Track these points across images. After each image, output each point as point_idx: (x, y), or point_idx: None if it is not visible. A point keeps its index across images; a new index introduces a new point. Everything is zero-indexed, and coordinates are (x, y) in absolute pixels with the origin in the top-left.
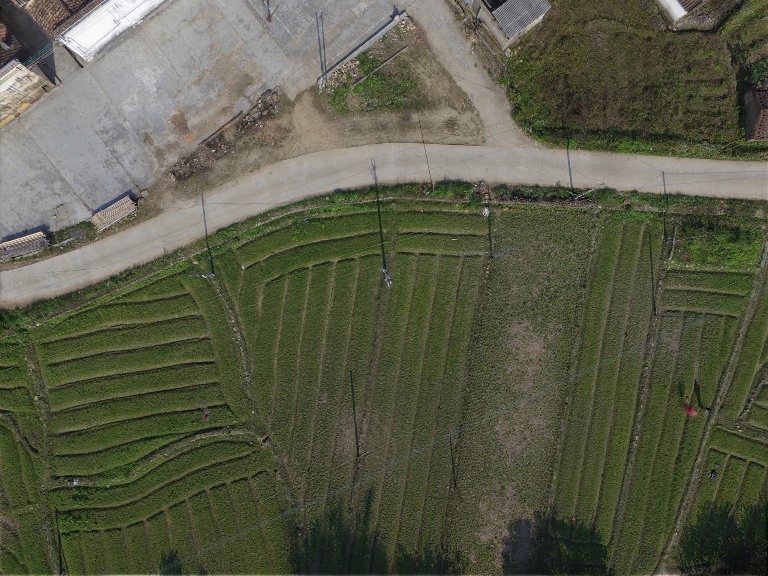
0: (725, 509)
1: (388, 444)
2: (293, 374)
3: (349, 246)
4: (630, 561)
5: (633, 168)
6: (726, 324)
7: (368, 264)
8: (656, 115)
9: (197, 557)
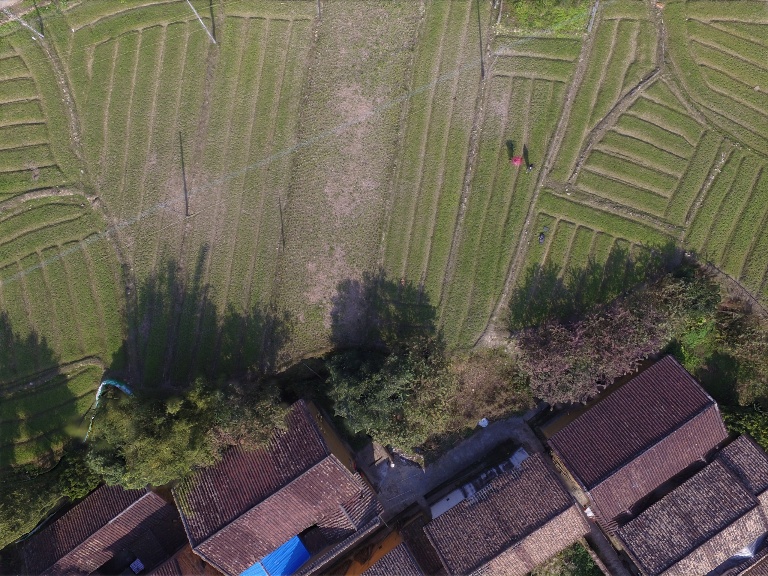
0: (554, 271)
1: (218, 205)
2: (123, 135)
3: (178, 9)
4: (459, 322)
5: None
6: (554, 88)
7: (197, 27)
8: None
9: (28, 318)
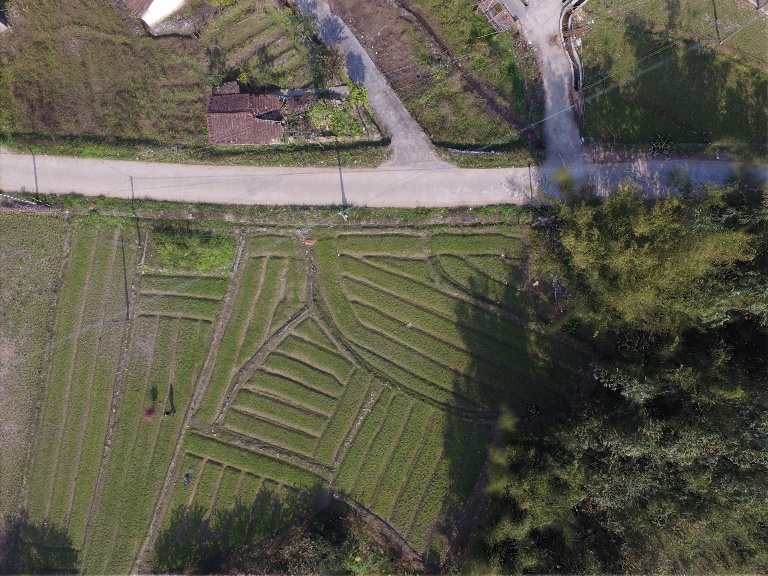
0: (199, 513)
1: None
2: None
3: None
4: (103, 565)
5: (100, 173)
6: (200, 328)
7: None
8: (126, 120)
9: None
